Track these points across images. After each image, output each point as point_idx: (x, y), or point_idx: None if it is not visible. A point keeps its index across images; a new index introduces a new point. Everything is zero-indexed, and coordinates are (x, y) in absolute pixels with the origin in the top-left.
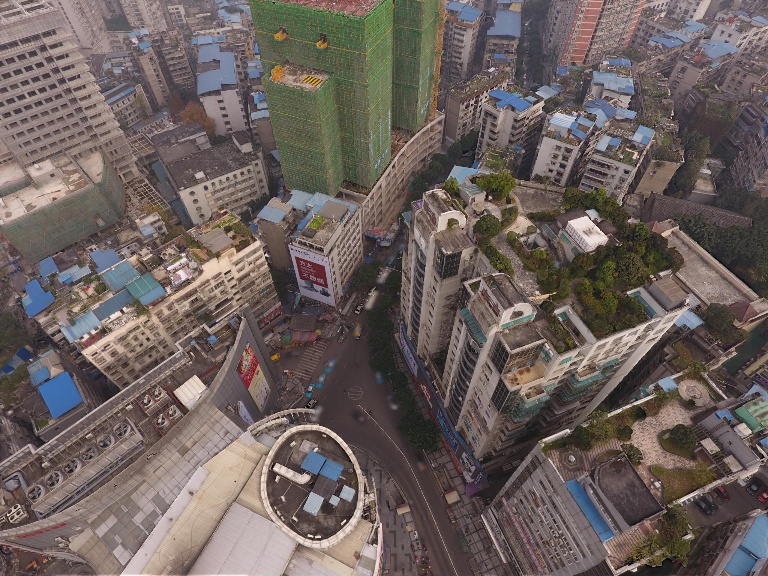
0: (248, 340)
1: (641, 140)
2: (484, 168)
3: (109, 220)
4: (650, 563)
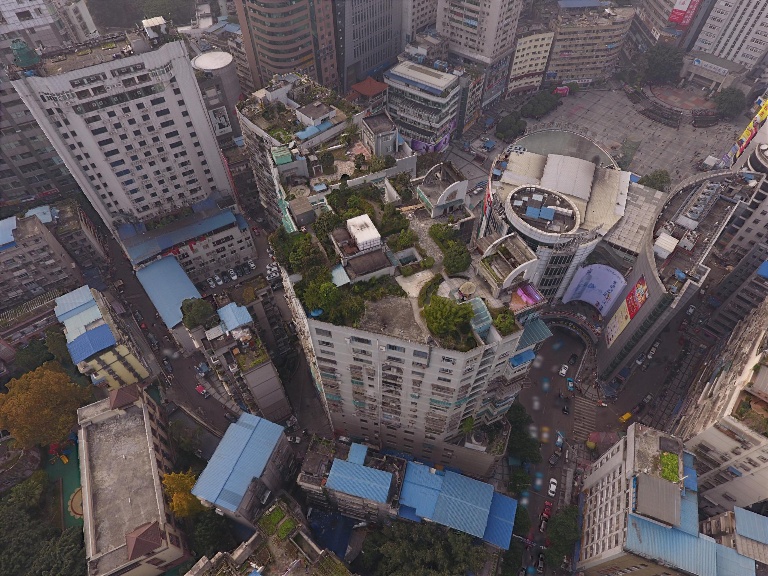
0: (650, 298)
1: None
2: None
3: None
4: None
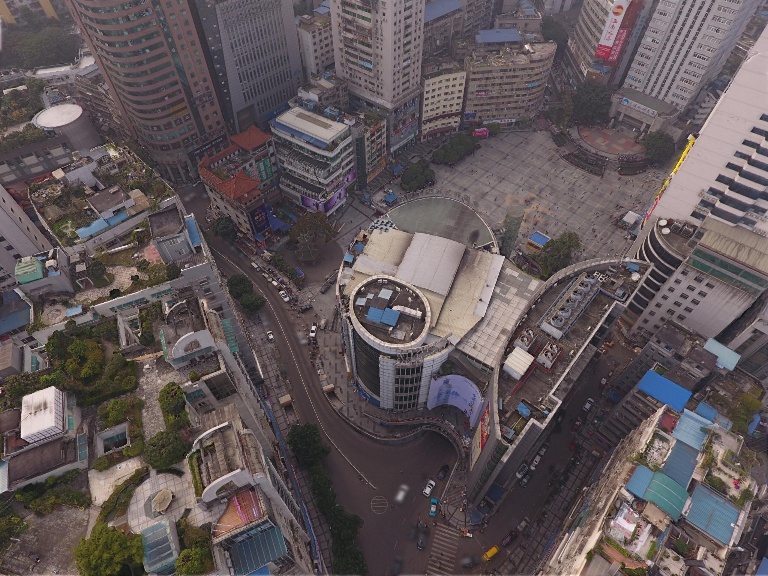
0: None
1: None
2: None
3: None
4: None
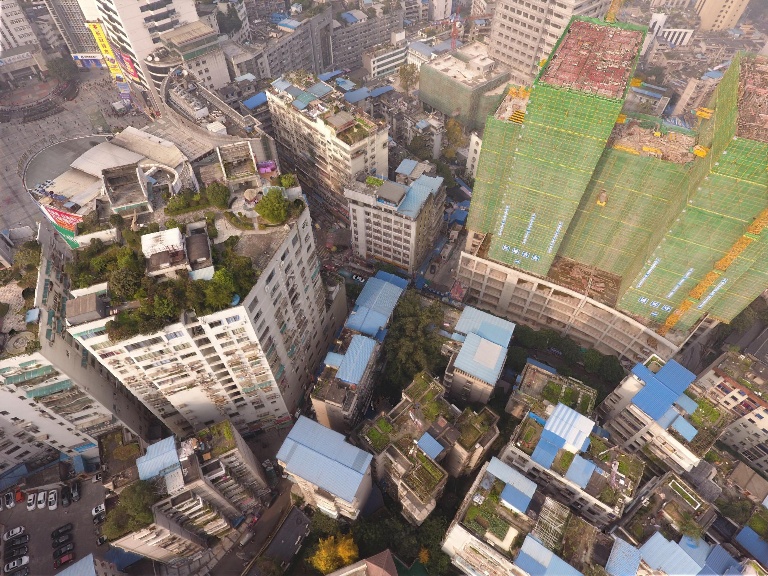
0: (257, 153)
1: (528, 554)
2: (543, 379)
3: (462, 119)
4: None
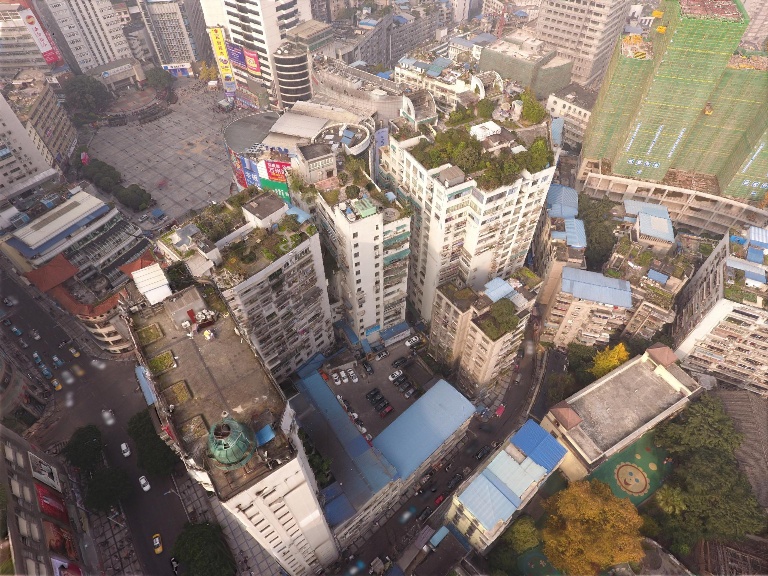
0: None
1: None
2: (695, 242)
3: None
4: (288, 177)
